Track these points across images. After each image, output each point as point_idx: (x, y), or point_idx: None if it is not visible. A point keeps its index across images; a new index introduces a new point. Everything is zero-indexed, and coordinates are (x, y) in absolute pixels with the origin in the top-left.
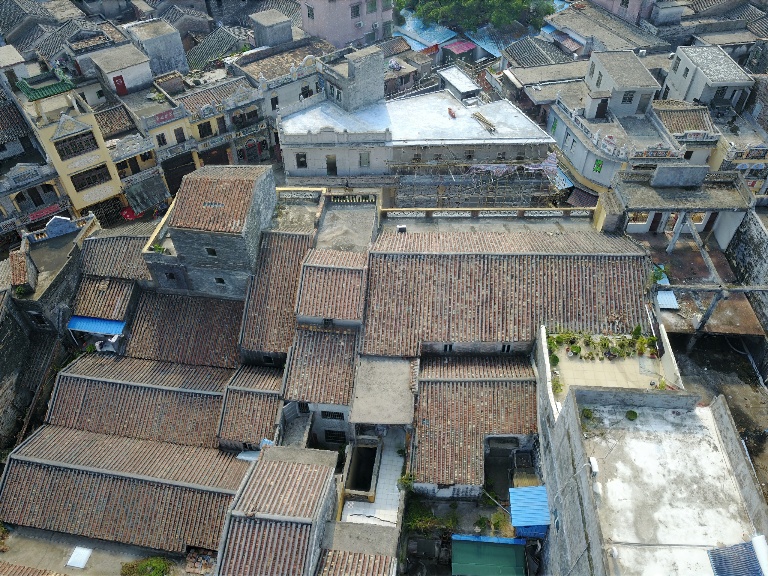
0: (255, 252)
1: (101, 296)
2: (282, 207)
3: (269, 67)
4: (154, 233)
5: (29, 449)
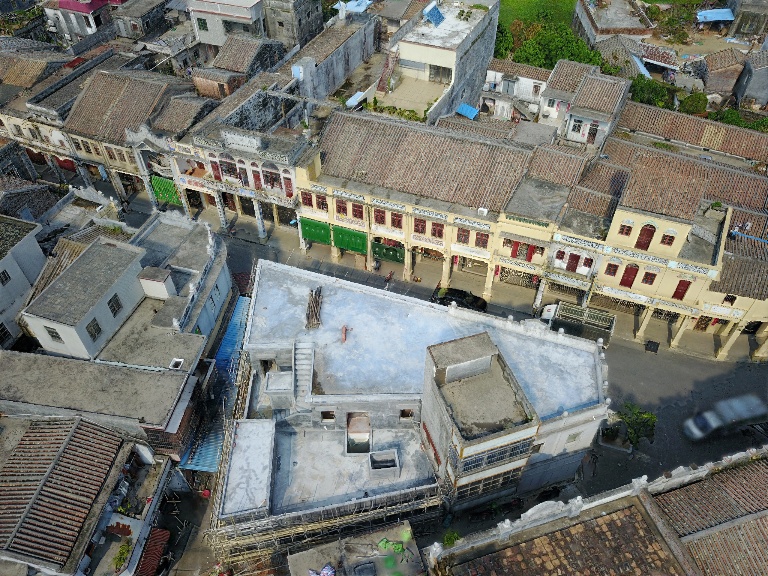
0: None
1: (766, 247)
2: (600, 239)
3: None
4: (728, 223)
5: (764, 186)
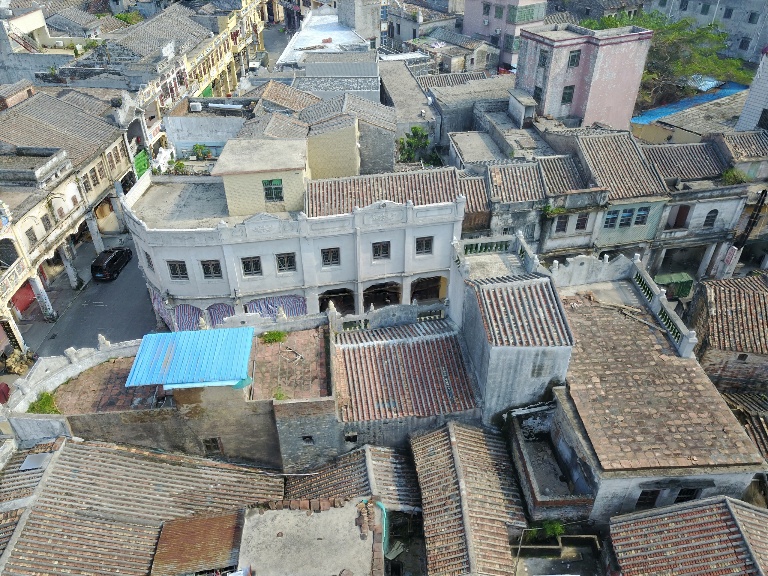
0: (201, 6)
1: None
2: None
3: (406, 7)
4: None
5: None
